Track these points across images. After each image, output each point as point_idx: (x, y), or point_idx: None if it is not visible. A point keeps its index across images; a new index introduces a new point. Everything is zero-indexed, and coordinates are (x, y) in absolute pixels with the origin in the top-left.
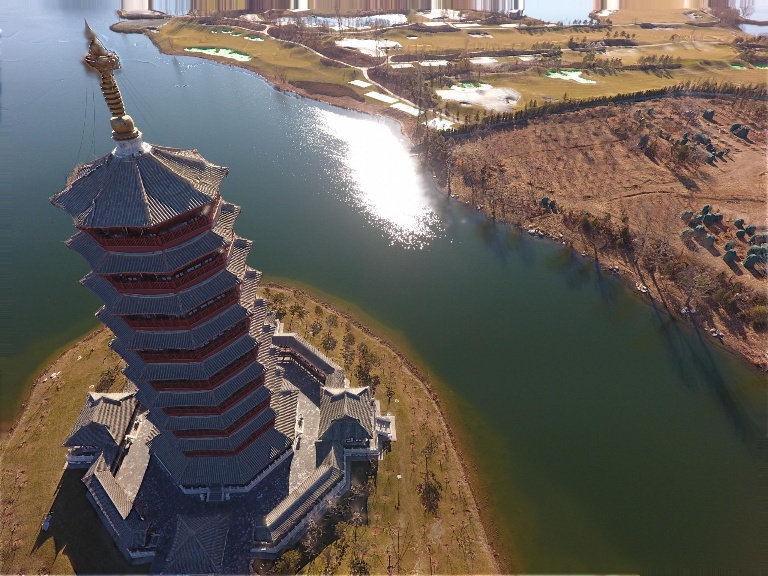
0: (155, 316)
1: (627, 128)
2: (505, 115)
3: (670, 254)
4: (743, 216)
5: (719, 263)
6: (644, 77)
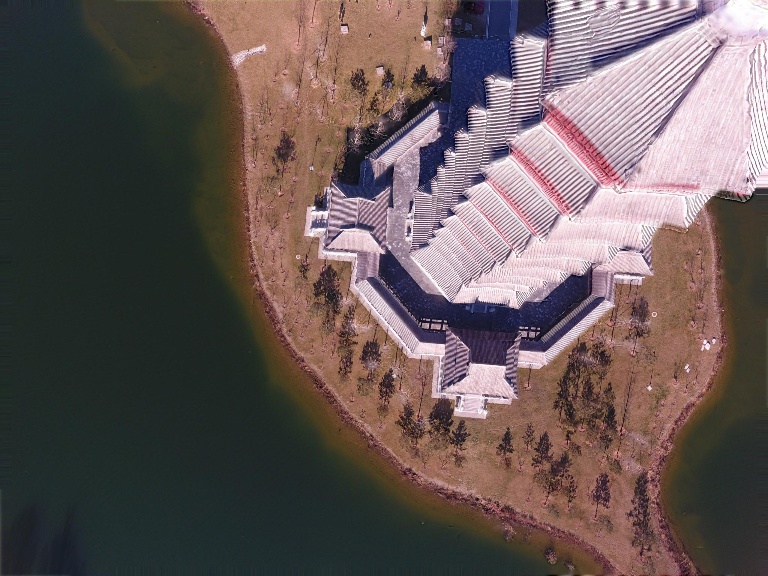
0: None
1: None
2: None
3: None
4: None
5: None
6: None
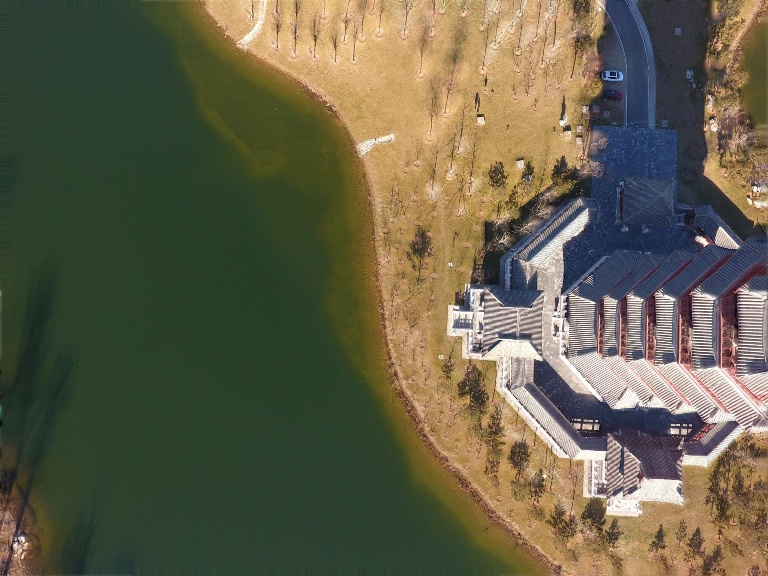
0: None
1: None
2: None
3: None
4: None
5: None
6: None
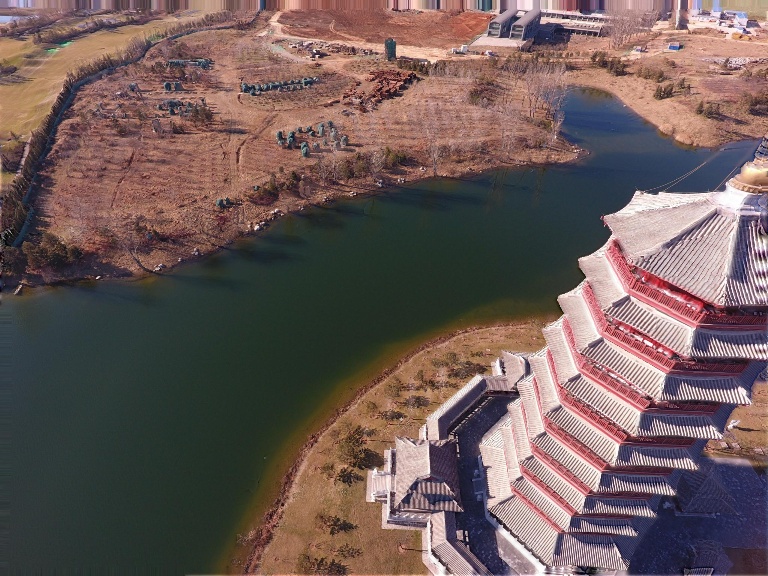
0: None
1: (125, 126)
2: (18, 183)
3: (343, 162)
4: (291, 127)
5: (341, 153)
6: (11, 89)
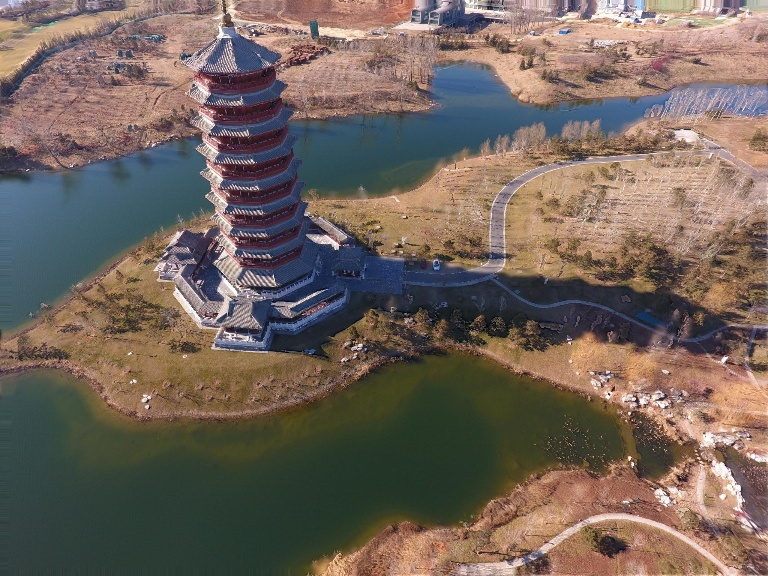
0: (279, 133)
1: None
2: None
3: None
4: None
5: None
6: None
